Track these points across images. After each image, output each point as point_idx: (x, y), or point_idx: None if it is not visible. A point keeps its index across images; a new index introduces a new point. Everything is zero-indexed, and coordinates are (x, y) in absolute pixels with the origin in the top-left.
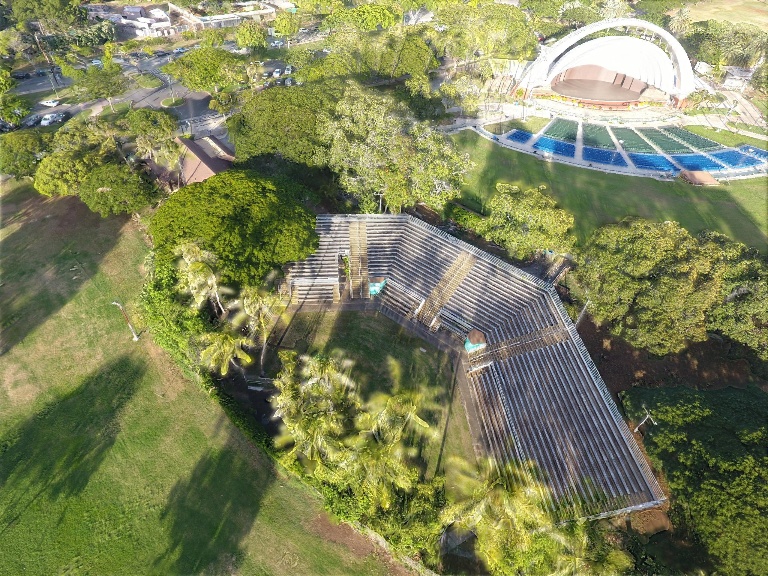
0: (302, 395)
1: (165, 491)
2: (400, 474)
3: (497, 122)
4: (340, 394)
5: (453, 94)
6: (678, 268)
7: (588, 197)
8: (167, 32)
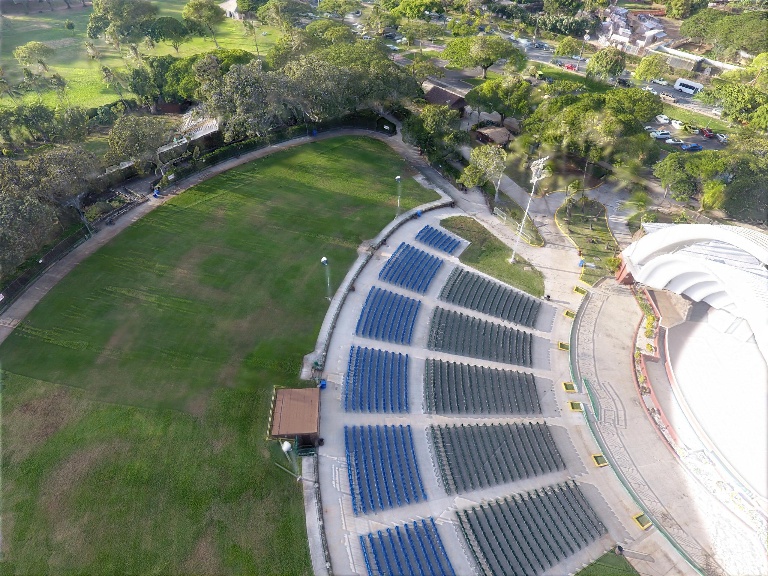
0: (54, 80)
1: (87, 106)
2: (41, 146)
3: (494, 233)
4: (75, 110)
5: (475, 157)
6: (7, 162)
7: (255, 252)
8: (615, 46)
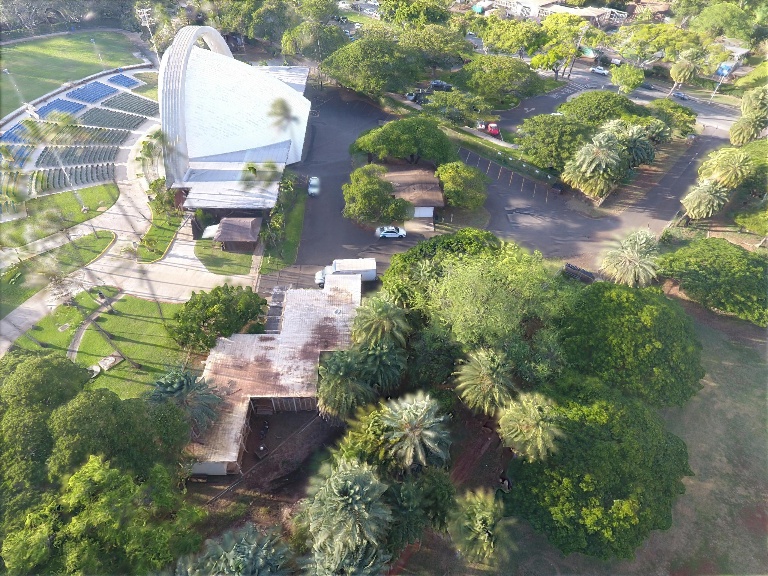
0: None
1: None
2: None
3: None
4: None
5: None
6: None
7: None
8: None
